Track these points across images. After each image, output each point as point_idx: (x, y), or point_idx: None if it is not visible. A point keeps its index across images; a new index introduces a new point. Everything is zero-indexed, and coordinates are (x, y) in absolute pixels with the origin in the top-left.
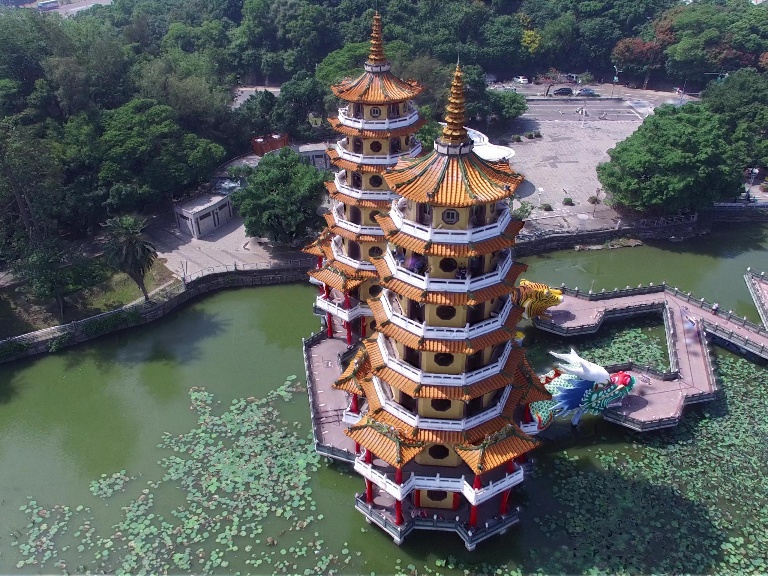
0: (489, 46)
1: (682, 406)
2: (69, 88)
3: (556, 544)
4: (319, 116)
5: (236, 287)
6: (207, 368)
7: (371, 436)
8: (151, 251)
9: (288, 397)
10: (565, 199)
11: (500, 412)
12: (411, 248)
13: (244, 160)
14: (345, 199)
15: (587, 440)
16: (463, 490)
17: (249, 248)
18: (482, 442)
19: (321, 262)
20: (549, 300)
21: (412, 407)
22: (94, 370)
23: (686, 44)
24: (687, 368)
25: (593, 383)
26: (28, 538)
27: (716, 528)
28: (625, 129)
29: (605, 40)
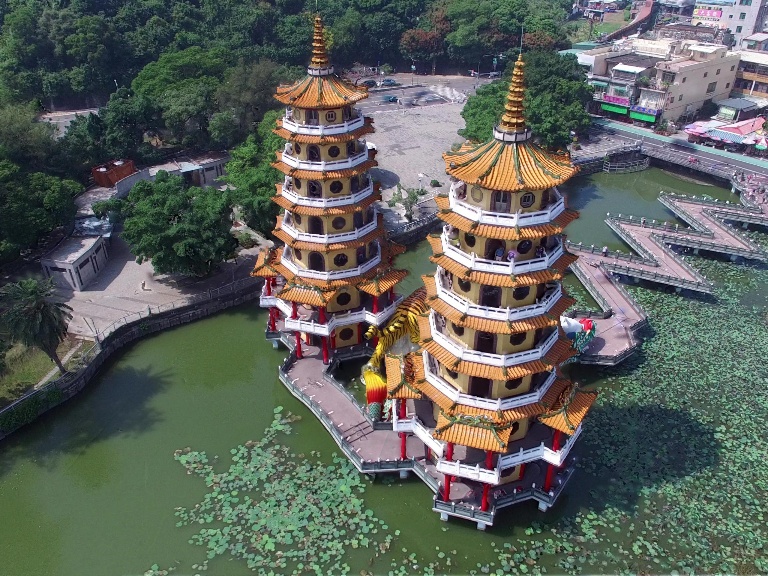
0: (286, 46)
1: (633, 335)
2: None
3: (605, 480)
4: (154, 135)
5: (153, 333)
6: (177, 427)
7: (462, 432)
8: (67, 313)
9: (288, 430)
10: (433, 182)
11: (556, 375)
12: (500, 237)
13: (90, 194)
14: (307, 211)
15: None
16: (543, 456)
17: (149, 288)
18: (558, 406)
19: (269, 283)
20: None
21: (483, 393)
22: (36, 469)
23: (464, 31)
24: (614, 304)
25: (575, 334)
26: None
27: (703, 424)
28: (440, 112)
29: (391, 33)
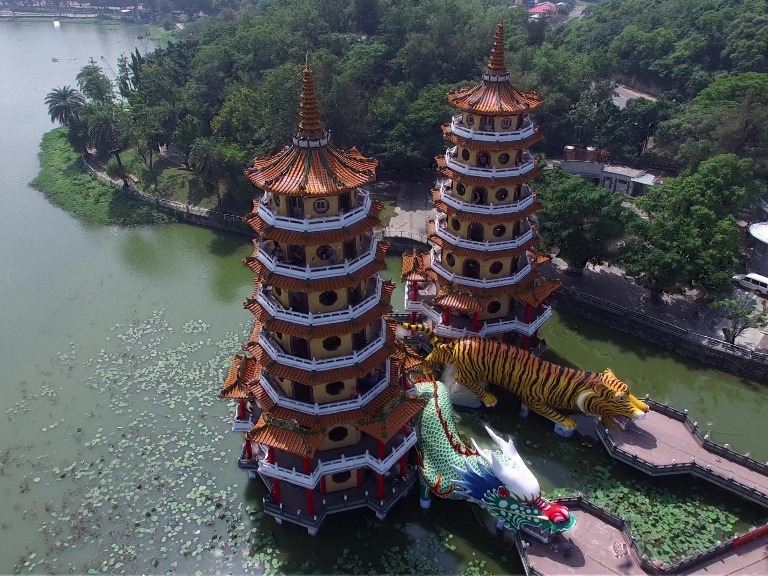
0: None
1: None
2: (413, 59)
3: None
4: None
5: None
6: None
7: None
8: None
9: None
10: None
11: (318, 413)
12: None
13: None
14: (436, 197)
15: (490, 547)
16: None
17: None
18: None
19: None
20: (620, 406)
21: None
22: None
23: None
24: None
25: (500, 484)
26: (138, 327)
27: None
28: None
29: None
